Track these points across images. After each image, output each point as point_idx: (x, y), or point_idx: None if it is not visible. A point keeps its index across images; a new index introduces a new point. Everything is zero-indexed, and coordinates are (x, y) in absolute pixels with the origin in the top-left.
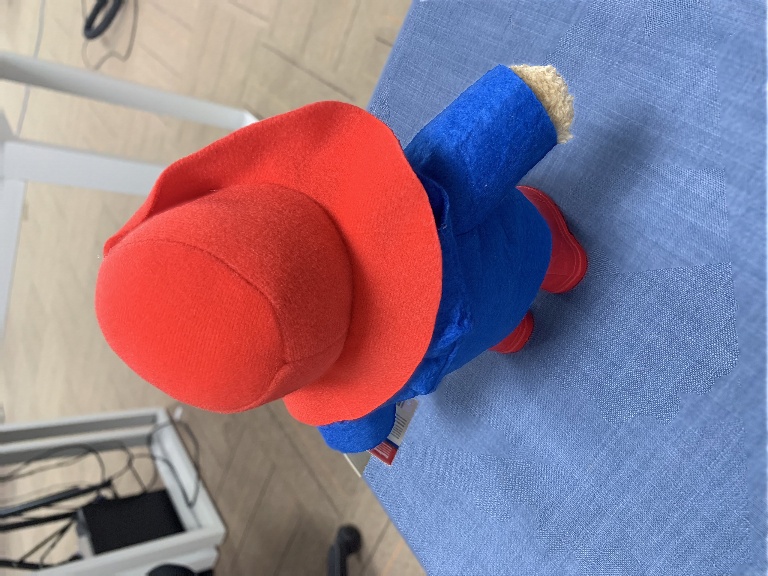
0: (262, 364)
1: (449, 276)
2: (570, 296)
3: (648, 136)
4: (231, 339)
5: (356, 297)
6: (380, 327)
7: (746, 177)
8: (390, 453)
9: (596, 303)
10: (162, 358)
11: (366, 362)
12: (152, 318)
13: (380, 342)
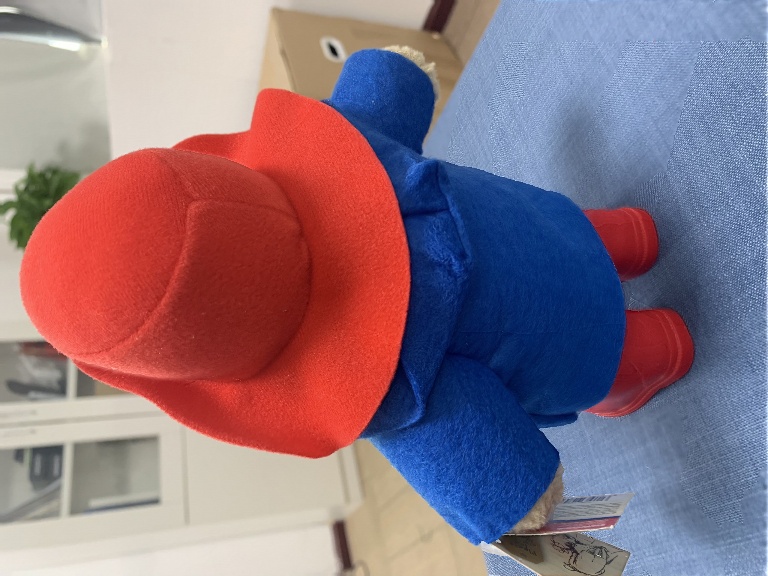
0: (162, 199)
1: (374, 140)
2: (664, 245)
3: (576, 111)
4: (117, 186)
5: (288, 191)
6: (325, 193)
7: (640, 21)
8: (607, 522)
9: (682, 212)
10: (60, 249)
11: (337, 236)
12: (49, 228)
13: (335, 206)
